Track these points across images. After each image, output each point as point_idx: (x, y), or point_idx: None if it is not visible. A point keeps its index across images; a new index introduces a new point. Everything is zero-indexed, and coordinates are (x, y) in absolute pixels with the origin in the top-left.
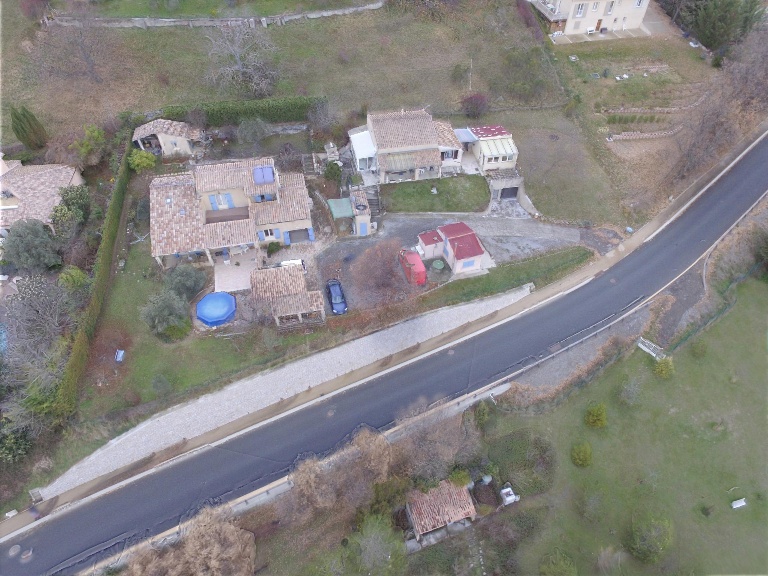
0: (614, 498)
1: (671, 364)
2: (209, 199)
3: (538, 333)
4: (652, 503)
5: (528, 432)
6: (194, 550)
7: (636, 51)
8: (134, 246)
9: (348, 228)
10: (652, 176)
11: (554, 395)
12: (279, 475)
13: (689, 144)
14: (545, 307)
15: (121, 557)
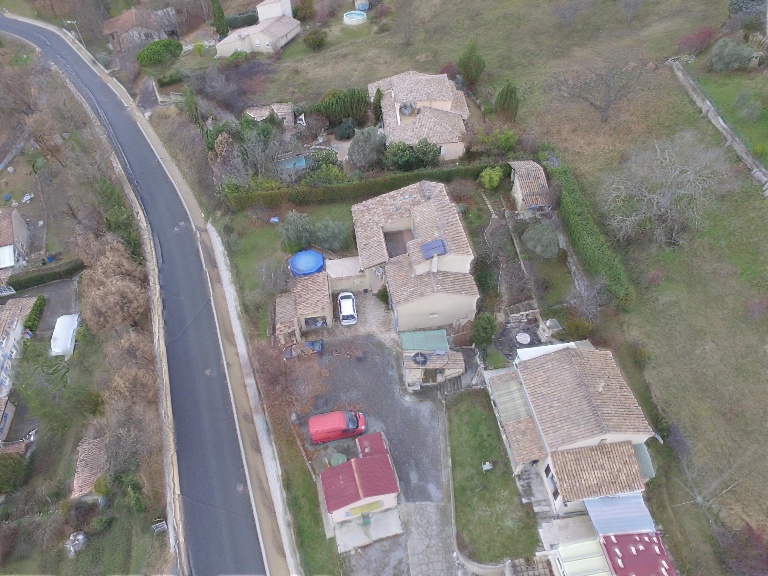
0: None
1: None
2: None
3: None
4: None
5: (122, 572)
6: None
7: None
8: None
9: None
10: None
11: None
12: None
13: None
14: None
15: None
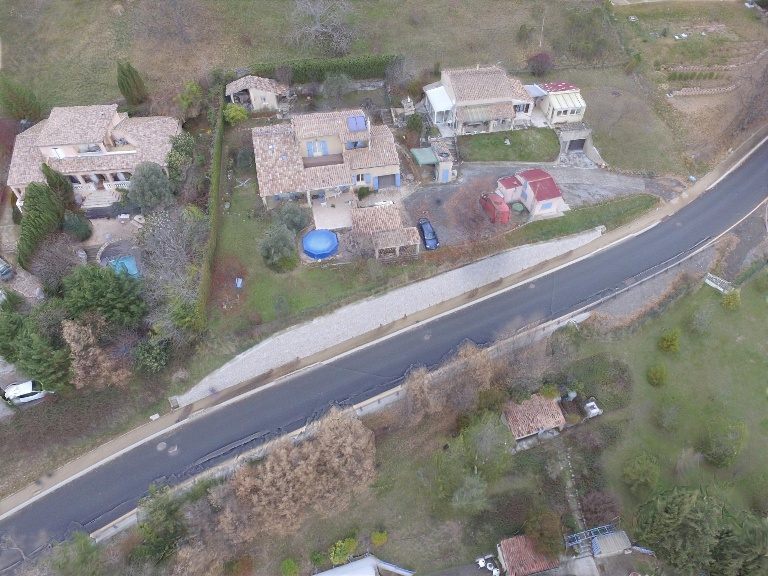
0: (688, 413)
1: (739, 296)
2: (306, 146)
3: (612, 269)
4: (723, 418)
5: (607, 355)
6: (330, 440)
7: (693, 11)
8: (235, 191)
9: (430, 175)
10: (712, 129)
11: (630, 324)
12: (389, 386)
13: (751, 97)
14: (616, 247)
15: (267, 444)
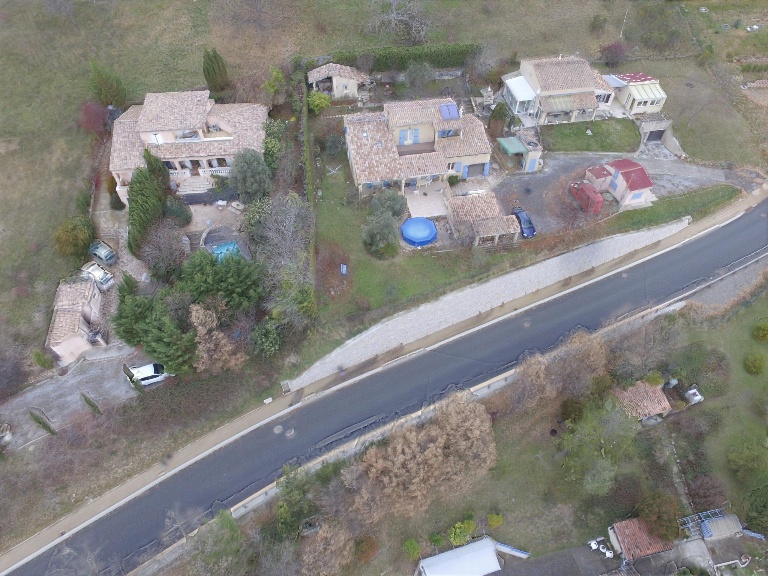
0: None
1: None
2: (399, 134)
3: (704, 259)
4: None
5: (705, 344)
6: (456, 423)
7: (763, 3)
8: (324, 178)
9: (515, 165)
10: None
11: (724, 313)
12: (498, 372)
13: None
14: (704, 238)
15: (395, 427)
